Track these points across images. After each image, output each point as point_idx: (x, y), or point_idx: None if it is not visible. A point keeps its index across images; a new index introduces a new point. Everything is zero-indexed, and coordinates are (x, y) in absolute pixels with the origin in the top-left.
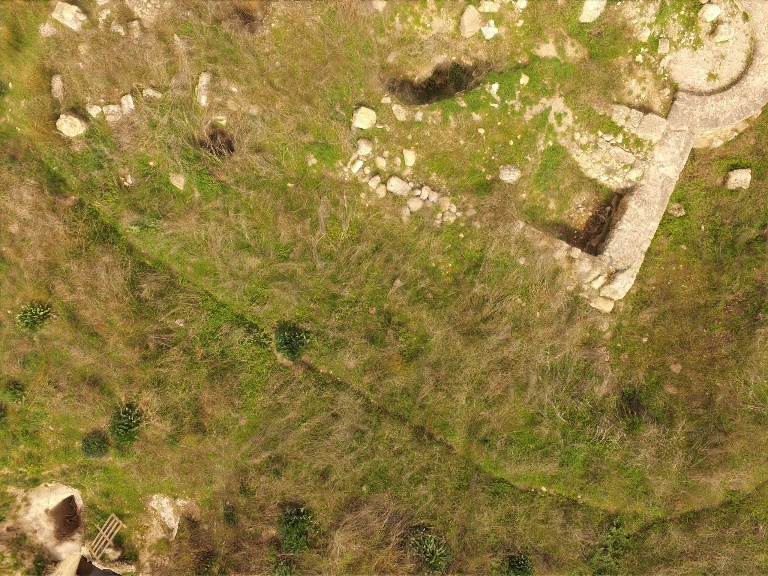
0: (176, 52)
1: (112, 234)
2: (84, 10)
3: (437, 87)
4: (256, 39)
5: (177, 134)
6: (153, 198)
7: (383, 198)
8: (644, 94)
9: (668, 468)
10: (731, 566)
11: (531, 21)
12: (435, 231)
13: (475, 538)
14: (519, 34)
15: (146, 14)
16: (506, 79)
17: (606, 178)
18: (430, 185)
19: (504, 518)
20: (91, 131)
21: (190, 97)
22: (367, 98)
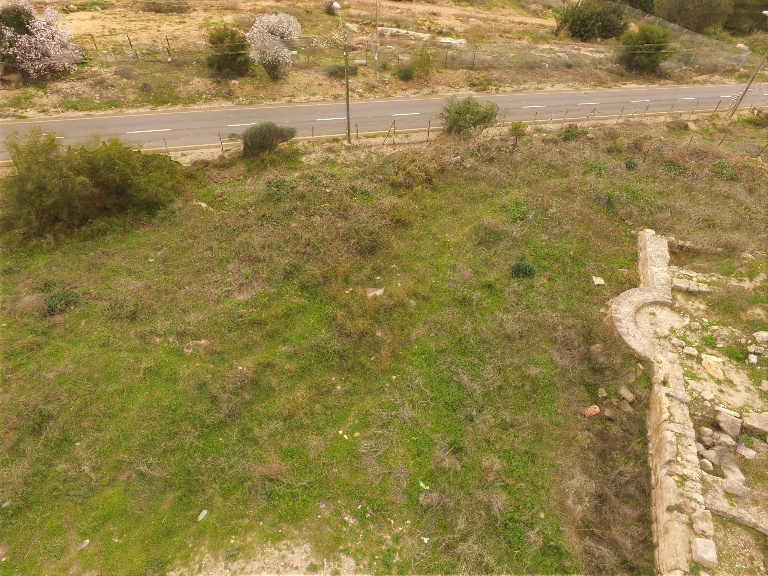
0: None
1: None
2: None
3: None
4: None
5: None
6: None
7: None
8: None
9: None
10: (552, 162)
11: None
12: (760, 248)
13: None
14: None
15: None
16: None
17: None
18: None
19: (645, 177)
20: None
21: None
22: None
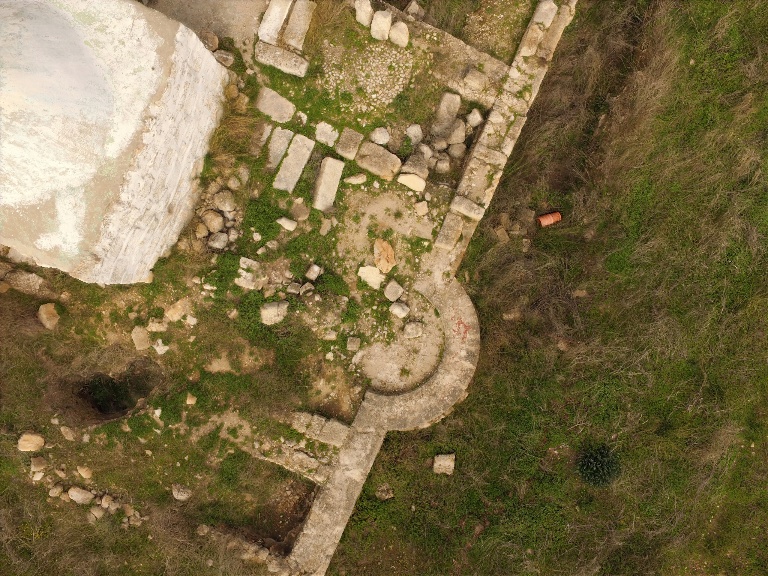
0: None
1: None
2: None
3: (137, 377)
4: None
5: None
6: None
7: None
8: (334, 392)
9: None
10: None
11: (203, 337)
12: (122, 534)
13: None
14: (192, 349)
15: None
16: (170, 403)
17: None
18: (112, 493)
19: None
20: None
21: None
22: (36, 419)
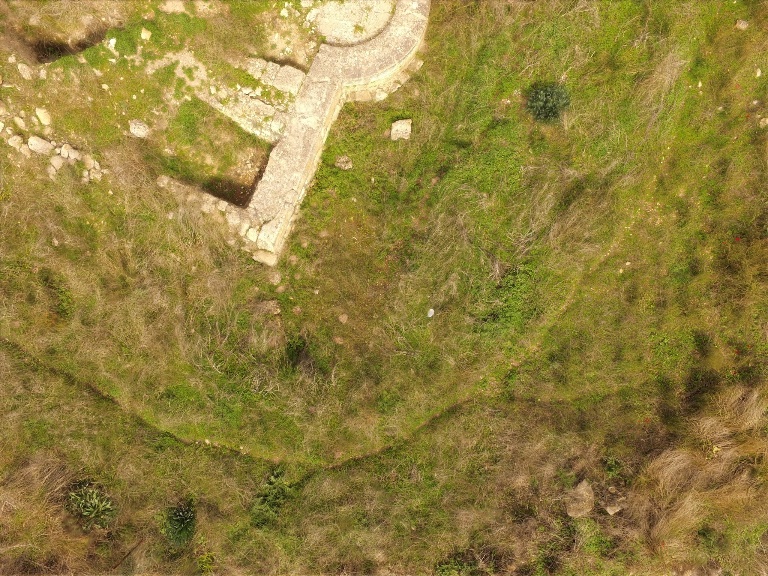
0: None
1: None
2: None
3: None
4: None
5: None
6: None
7: (31, 158)
8: (290, 48)
9: (316, 415)
10: (380, 510)
11: None
12: (83, 189)
13: (140, 492)
14: None
15: None
16: (124, 34)
17: (258, 132)
18: (72, 143)
19: (168, 471)
20: None
21: None
22: None
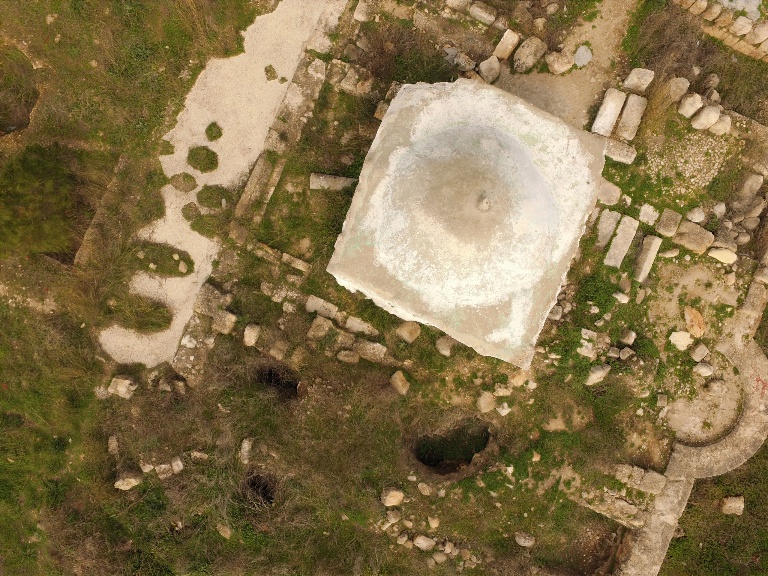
0: (221, 428)
1: (166, 575)
2: (135, 378)
3: (456, 432)
4: (293, 417)
5: (223, 493)
6: (202, 545)
7: None
8: (645, 444)
9: None
10: None
11: (541, 399)
12: None
13: None
14: (530, 410)
15: (191, 378)
16: (520, 461)
17: None
18: (452, 540)
19: None
20: (145, 484)
21: (233, 457)
22: (395, 476)
